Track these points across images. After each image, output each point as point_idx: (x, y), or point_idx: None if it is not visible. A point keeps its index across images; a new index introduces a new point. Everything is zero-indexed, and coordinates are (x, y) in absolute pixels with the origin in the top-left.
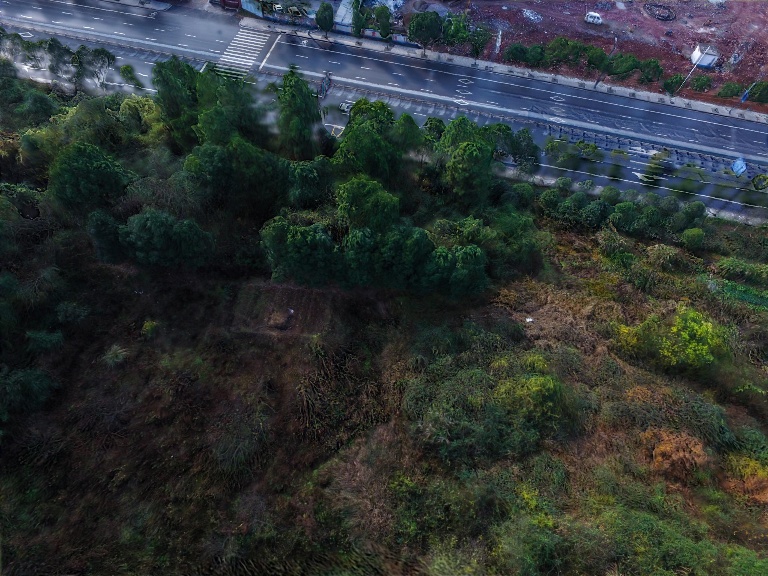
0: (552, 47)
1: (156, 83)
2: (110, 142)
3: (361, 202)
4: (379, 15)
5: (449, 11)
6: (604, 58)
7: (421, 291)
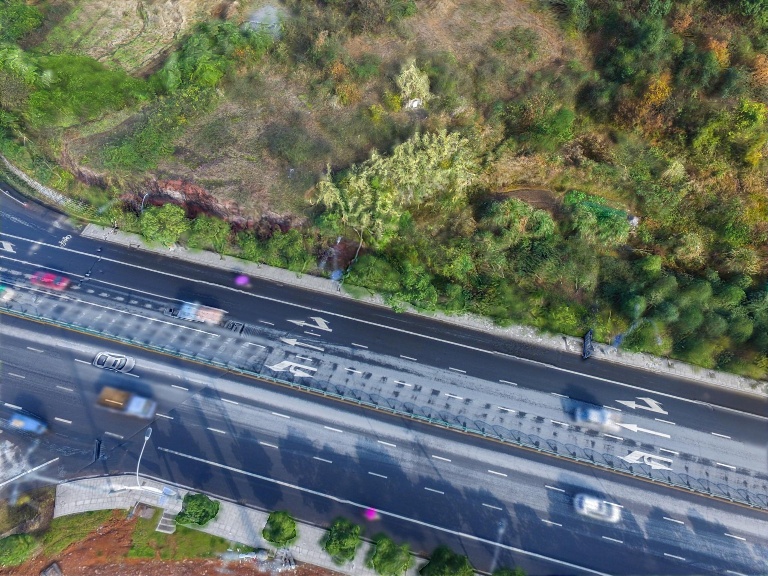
0: None
1: None
2: None
3: None
4: None
5: None
6: None
7: None
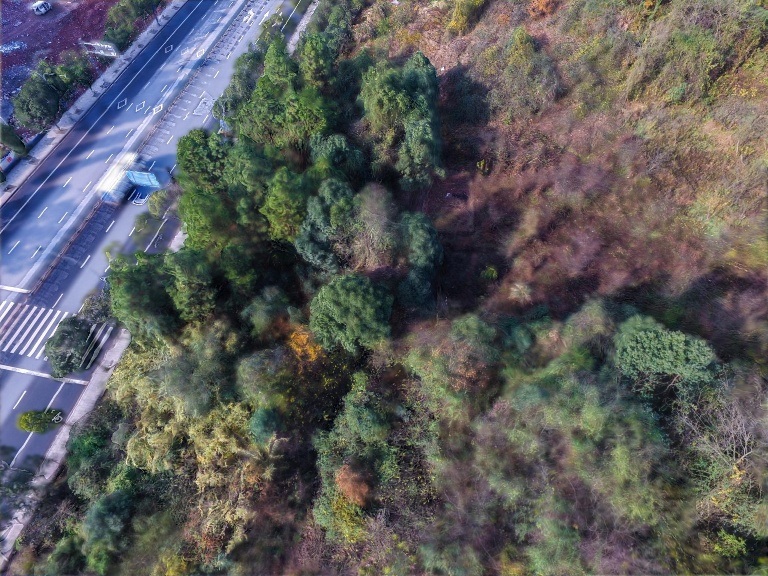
0: (119, 20)
1: (184, 271)
2: (222, 380)
3: (399, 85)
4: (2, 135)
5: None
6: None
7: (440, 101)
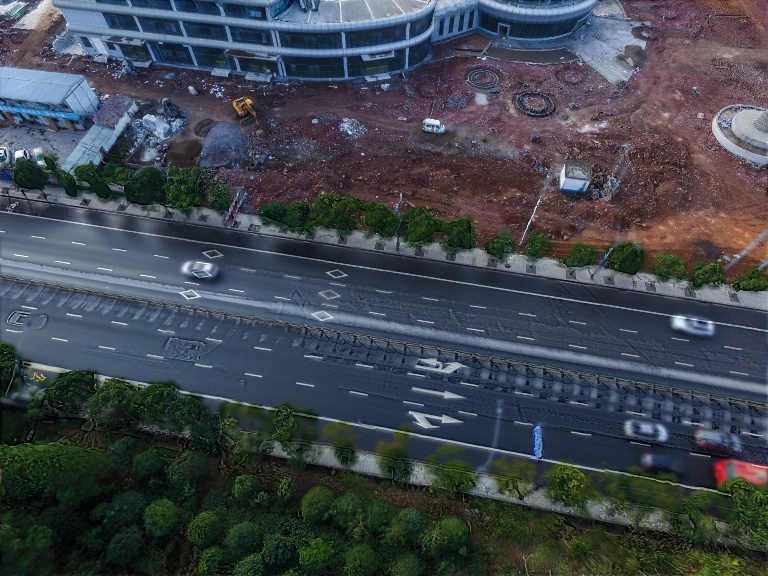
0: (315, 209)
1: None
2: None
3: None
4: (80, 177)
5: (235, 134)
6: (386, 223)
7: None
